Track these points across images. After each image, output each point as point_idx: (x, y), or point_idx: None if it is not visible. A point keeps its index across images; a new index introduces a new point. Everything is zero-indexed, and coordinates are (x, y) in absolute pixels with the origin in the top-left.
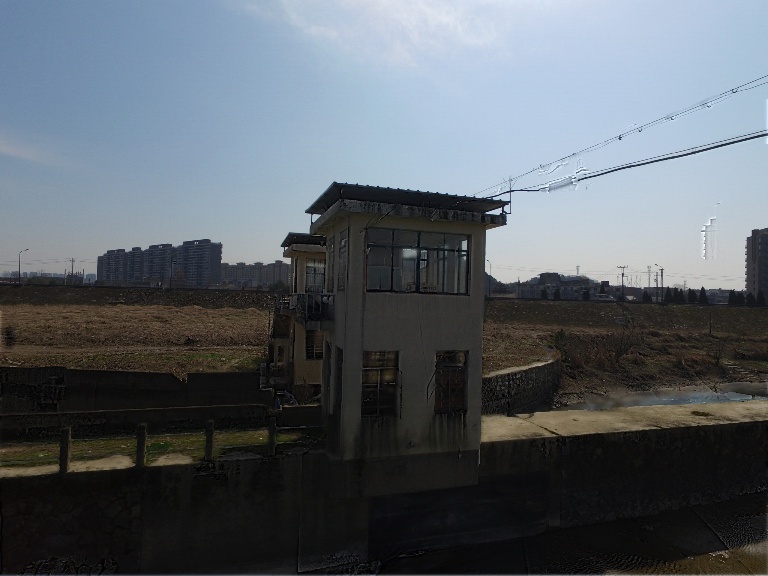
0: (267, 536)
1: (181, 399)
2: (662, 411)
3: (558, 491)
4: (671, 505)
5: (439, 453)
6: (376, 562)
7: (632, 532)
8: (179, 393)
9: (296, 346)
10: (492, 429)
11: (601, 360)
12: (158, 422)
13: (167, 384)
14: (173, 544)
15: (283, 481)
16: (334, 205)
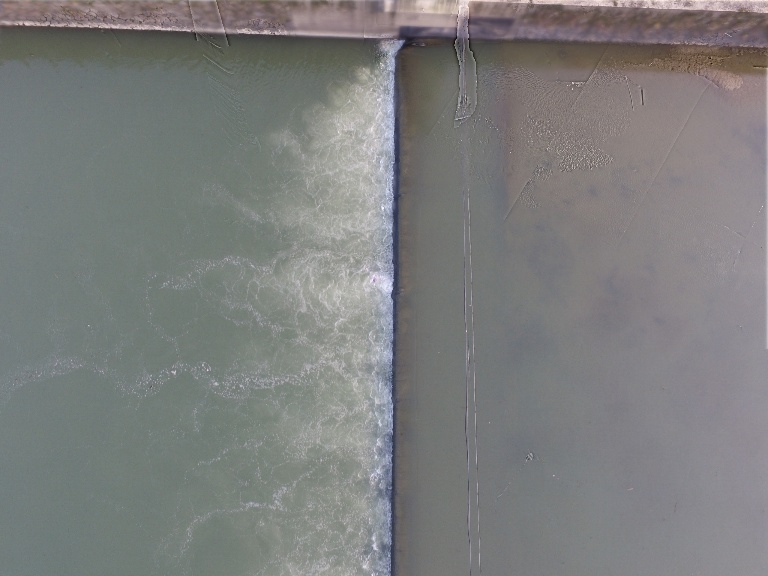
0: (349, 24)
1: None
2: None
3: (518, 27)
4: (596, 42)
5: (439, 14)
6: (403, 40)
7: (551, 55)
8: None
9: None
10: None
11: None
12: None
13: None
14: (306, 21)
15: (355, 6)
16: None
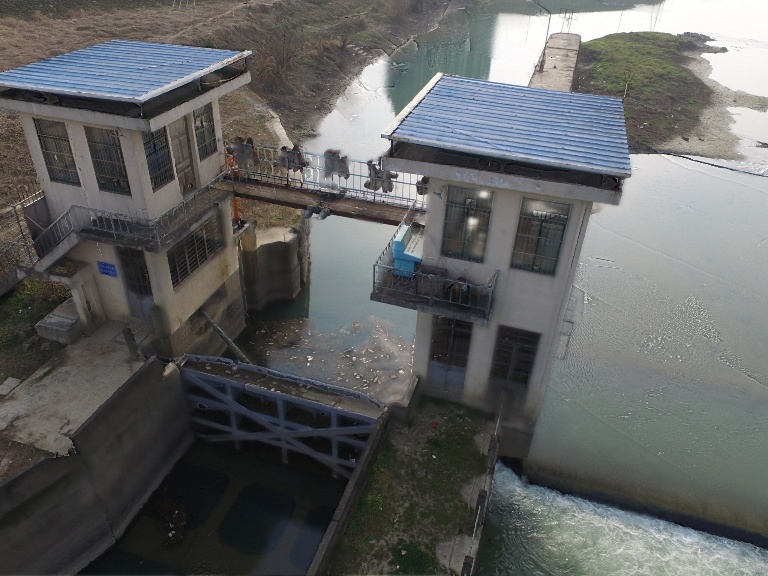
0: None
1: (81, 479)
2: None
3: None
4: None
5: None
6: None
7: None
8: (74, 474)
9: (162, 282)
10: None
11: (271, 78)
12: (337, 540)
13: (44, 479)
14: None
15: None
16: (590, 190)
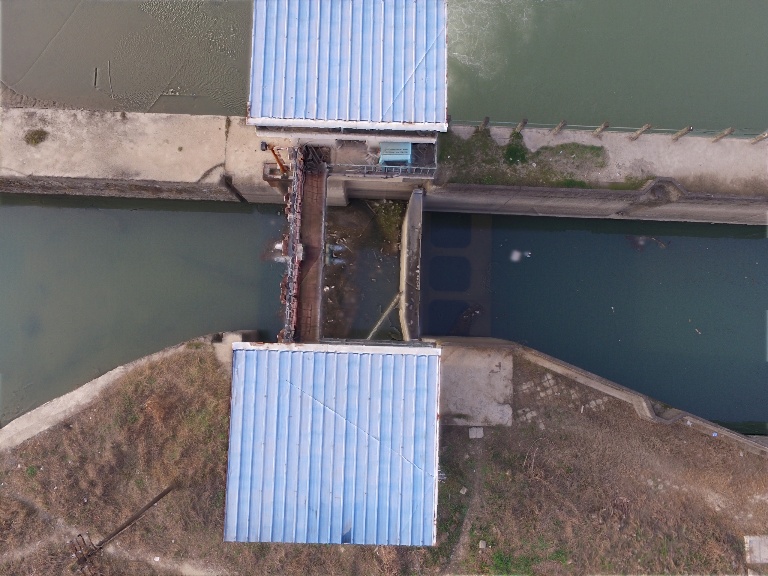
0: None
1: None
2: (65, 154)
3: None
4: None
5: None
6: None
7: None
8: None
9: None
10: (272, 142)
11: None
12: None
13: None
14: None
15: None
16: None
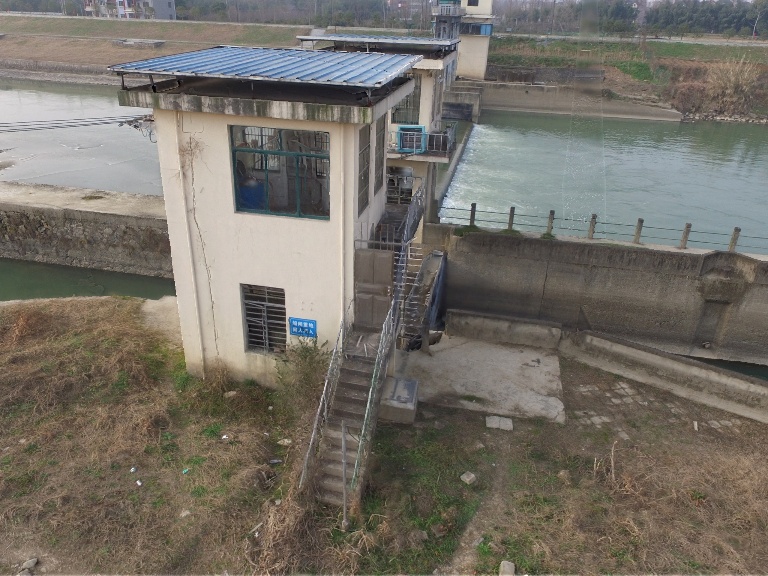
0: None
1: None
2: (109, 204)
3: None
4: None
5: None
6: None
7: None
8: None
9: None
10: None
11: None
12: None
13: None
14: None
15: None
16: None
